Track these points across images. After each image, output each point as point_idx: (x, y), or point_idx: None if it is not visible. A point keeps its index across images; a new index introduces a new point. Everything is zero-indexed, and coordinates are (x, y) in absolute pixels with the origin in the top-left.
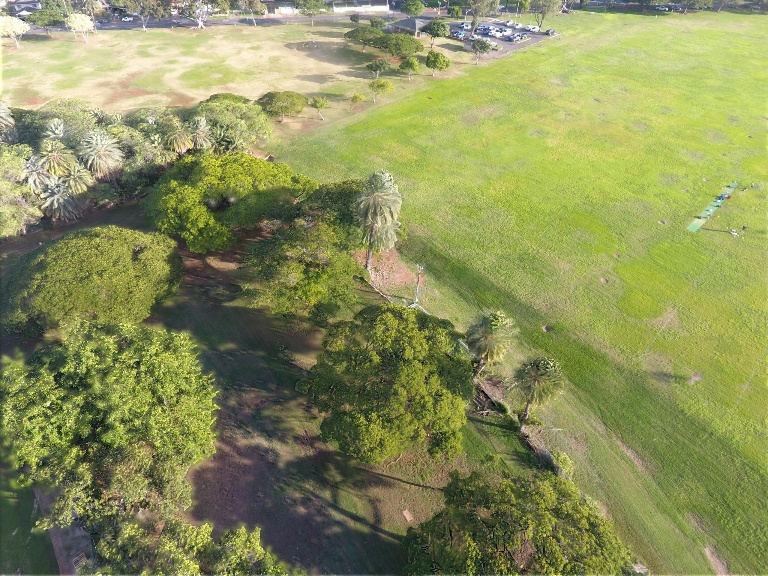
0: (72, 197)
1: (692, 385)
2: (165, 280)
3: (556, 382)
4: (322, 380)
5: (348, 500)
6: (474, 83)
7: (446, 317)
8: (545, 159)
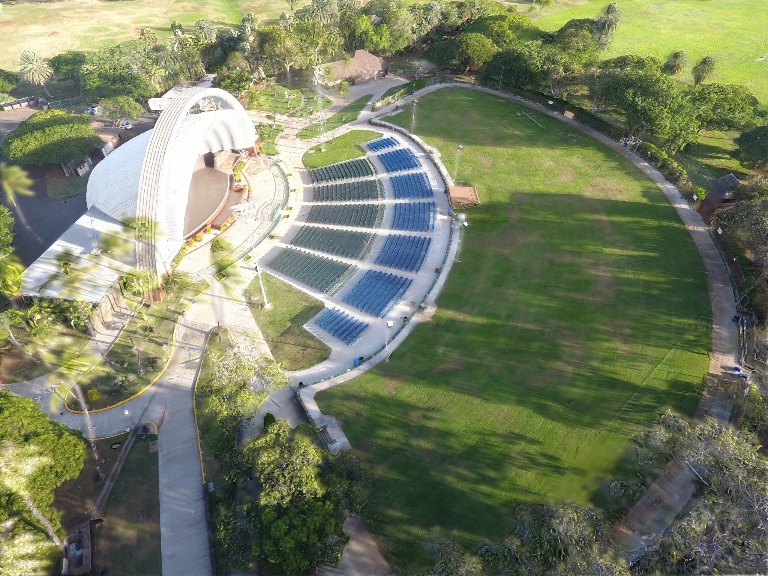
0: (420, 36)
1: (764, 98)
2: None
3: (712, 67)
4: None
5: None
6: (598, 7)
7: None
8: (663, 37)
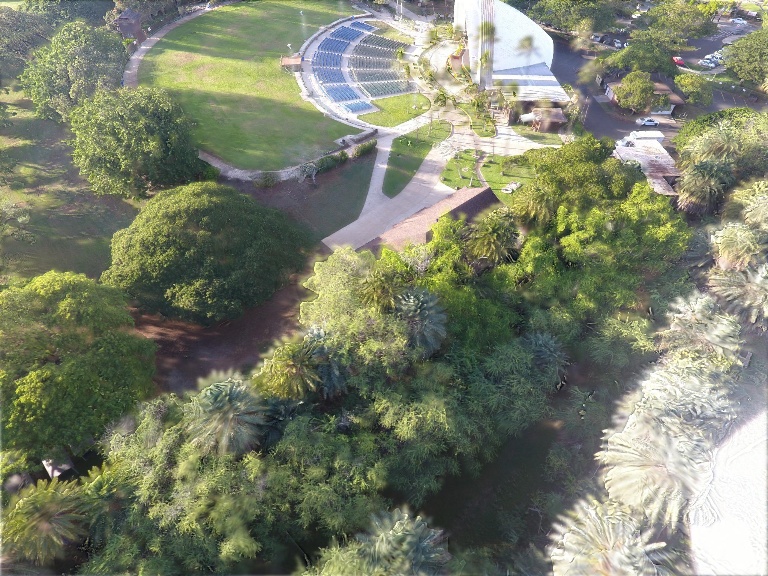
0: None
1: None
2: None
3: None
4: None
5: (27, 171)
6: None
7: None
8: None
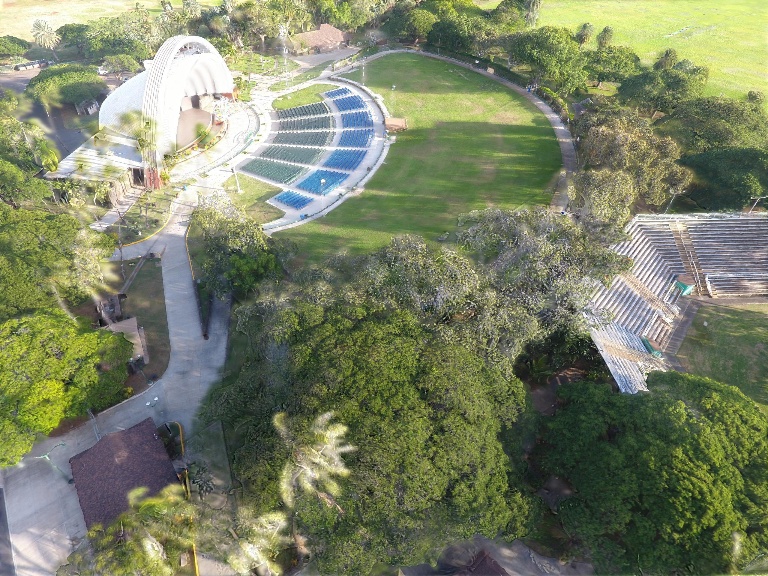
0: (379, 15)
1: None
2: None
3: (611, 35)
4: None
5: None
6: None
7: None
8: (592, 19)
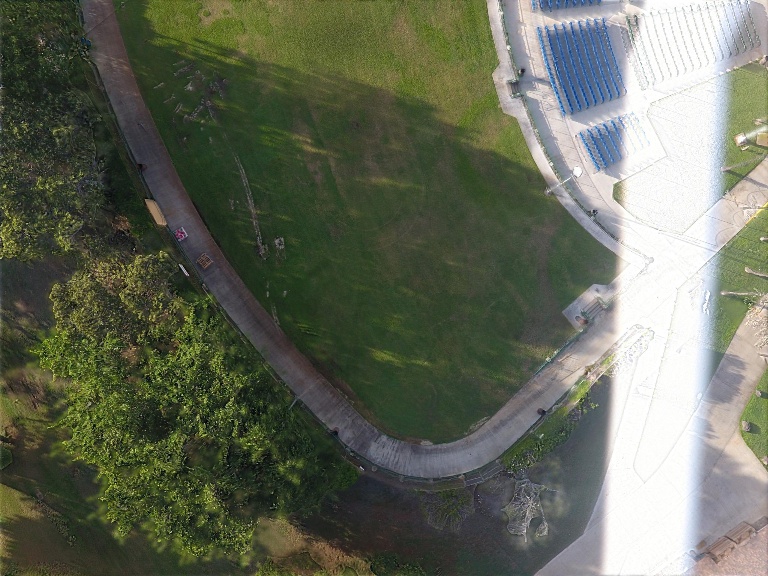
0: None
1: None
2: None
3: None
4: None
5: None
6: None
7: None
8: None
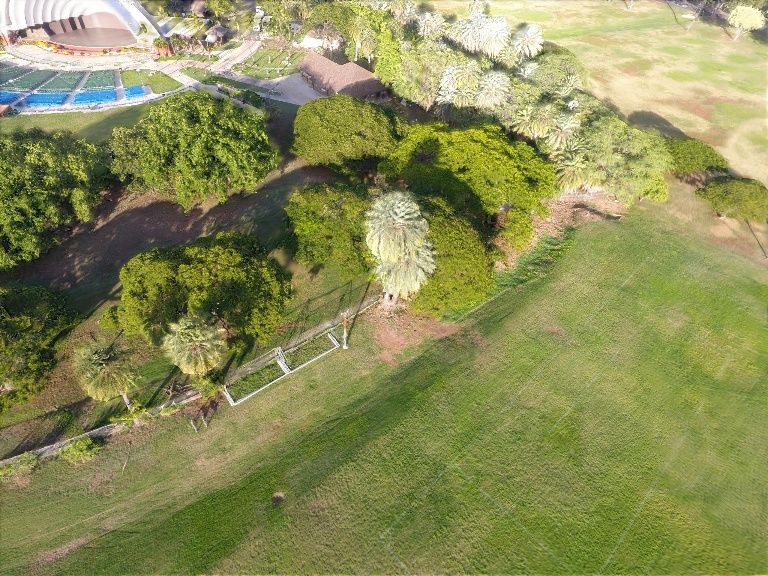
0: (451, 106)
1: None
2: (342, 159)
3: None
4: (201, 238)
5: None
6: None
7: (316, 375)
8: None
